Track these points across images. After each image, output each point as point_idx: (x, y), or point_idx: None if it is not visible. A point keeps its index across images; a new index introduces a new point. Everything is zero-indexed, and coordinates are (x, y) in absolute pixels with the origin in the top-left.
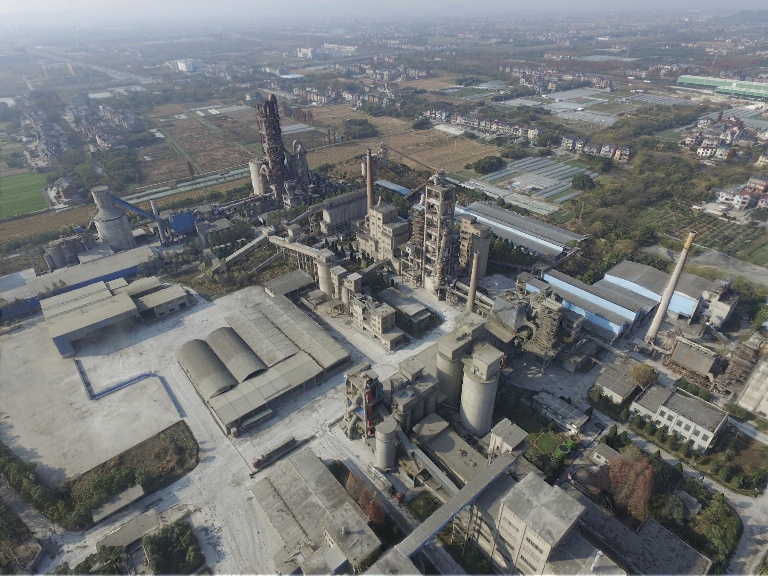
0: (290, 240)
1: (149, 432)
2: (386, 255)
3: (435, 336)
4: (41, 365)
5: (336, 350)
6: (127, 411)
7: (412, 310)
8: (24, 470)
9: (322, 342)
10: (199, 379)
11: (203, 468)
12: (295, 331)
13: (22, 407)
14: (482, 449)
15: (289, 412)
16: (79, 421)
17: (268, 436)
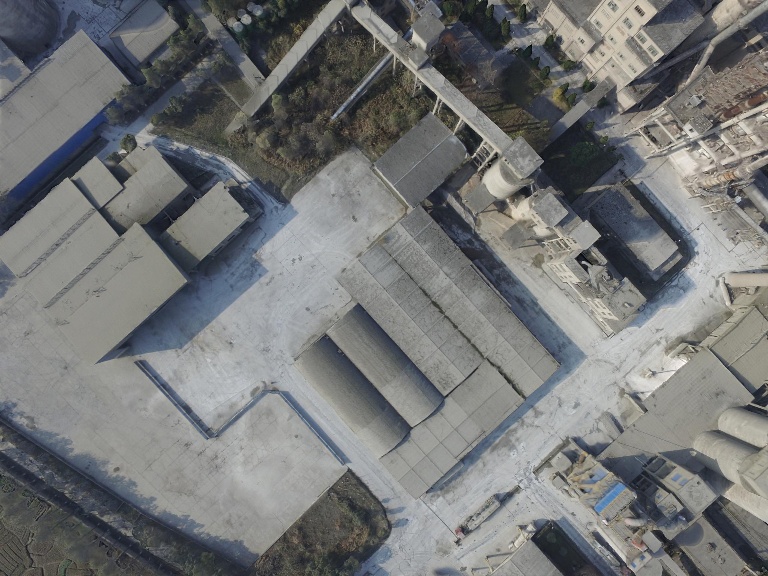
0: (421, 64)
1: (313, 488)
2: (610, 72)
3: (676, 294)
4: (93, 373)
5: (538, 360)
6: (268, 456)
7: (656, 257)
8: (206, 570)
9: (515, 342)
10: (353, 426)
11: (399, 535)
12: (467, 315)
13: (124, 453)
14: (725, 518)
15: (480, 452)
16: (215, 474)
17: (462, 489)
